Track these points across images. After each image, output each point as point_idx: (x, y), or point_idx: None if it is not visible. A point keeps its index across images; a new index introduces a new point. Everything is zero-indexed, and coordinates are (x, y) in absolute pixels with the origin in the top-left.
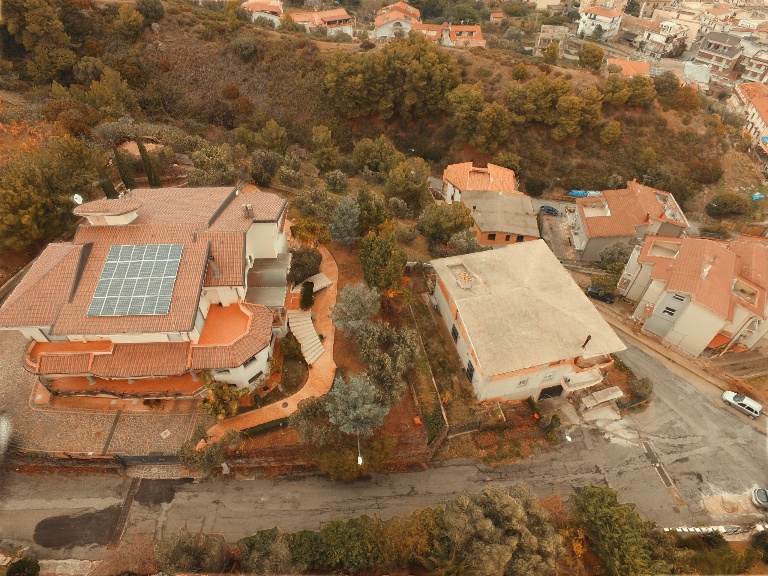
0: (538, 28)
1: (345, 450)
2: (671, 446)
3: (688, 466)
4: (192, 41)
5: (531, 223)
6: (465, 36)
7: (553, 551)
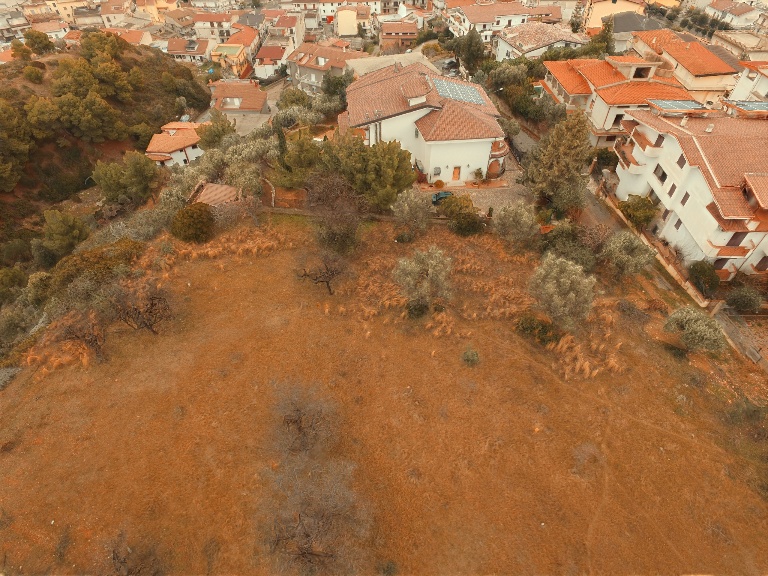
0: None
1: None
2: None
3: None
4: None
5: (256, 116)
6: None
7: None
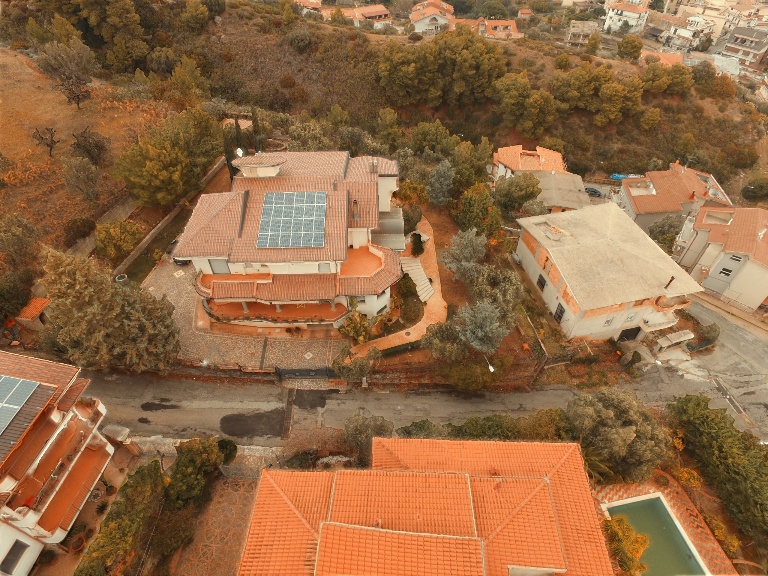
0: (565, 24)
1: (472, 365)
2: (738, 382)
3: (755, 398)
4: (251, 33)
5: (584, 199)
6: (501, 30)
7: (663, 440)
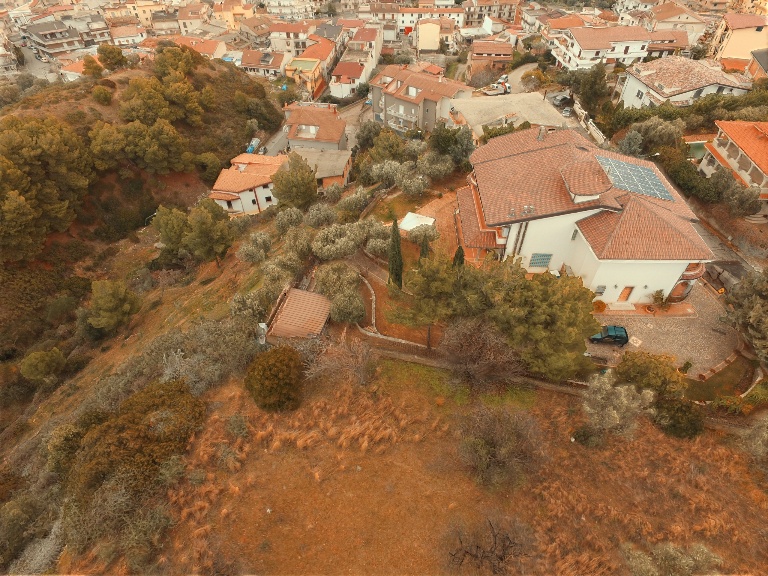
0: None
1: None
2: None
3: None
4: None
5: (335, 152)
6: None
7: None
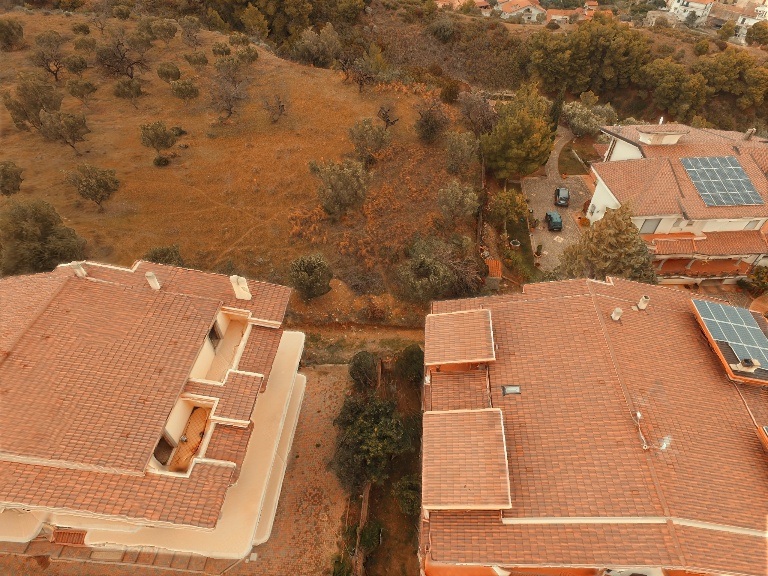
0: None
1: None
2: None
3: None
4: (398, 23)
5: None
6: None
7: None
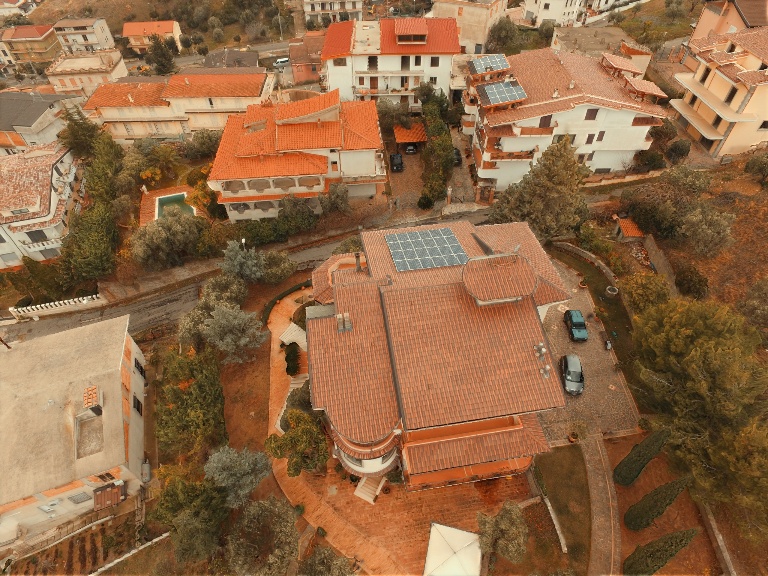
0: None
1: None
2: None
3: None
4: None
5: None
6: None
7: None
